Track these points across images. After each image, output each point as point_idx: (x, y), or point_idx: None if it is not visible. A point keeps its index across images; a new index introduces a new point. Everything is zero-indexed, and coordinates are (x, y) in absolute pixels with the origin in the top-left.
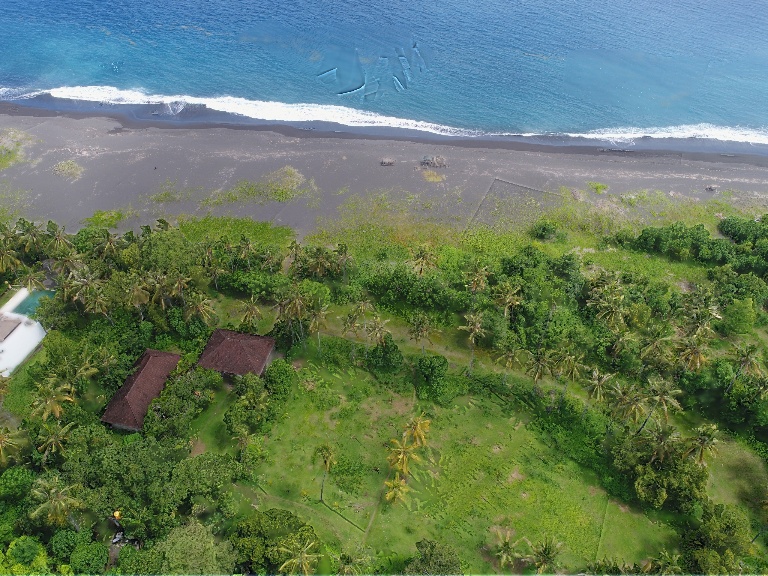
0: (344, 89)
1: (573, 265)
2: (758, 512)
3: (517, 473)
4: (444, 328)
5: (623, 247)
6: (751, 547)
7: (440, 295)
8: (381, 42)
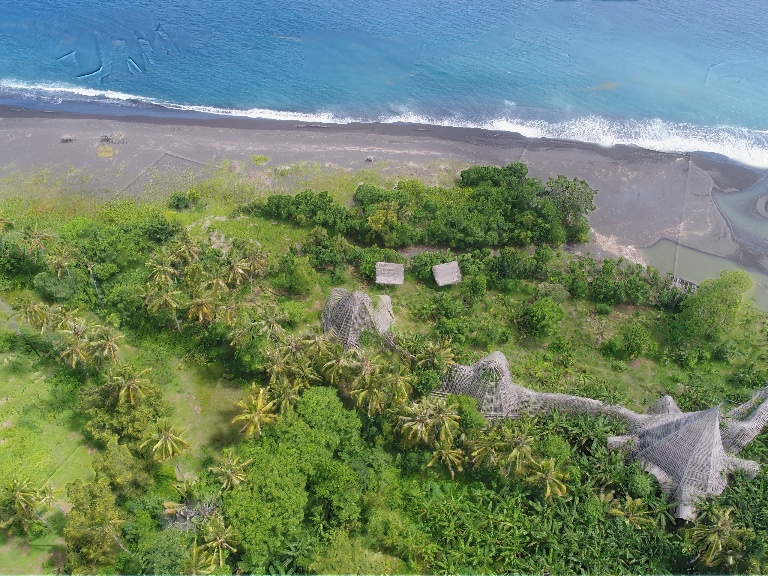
0: (84, 72)
1: (167, 230)
2: None
3: (9, 422)
4: (28, 292)
5: (254, 215)
6: (121, 475)
7: (24, 260)
8: (119, 25)
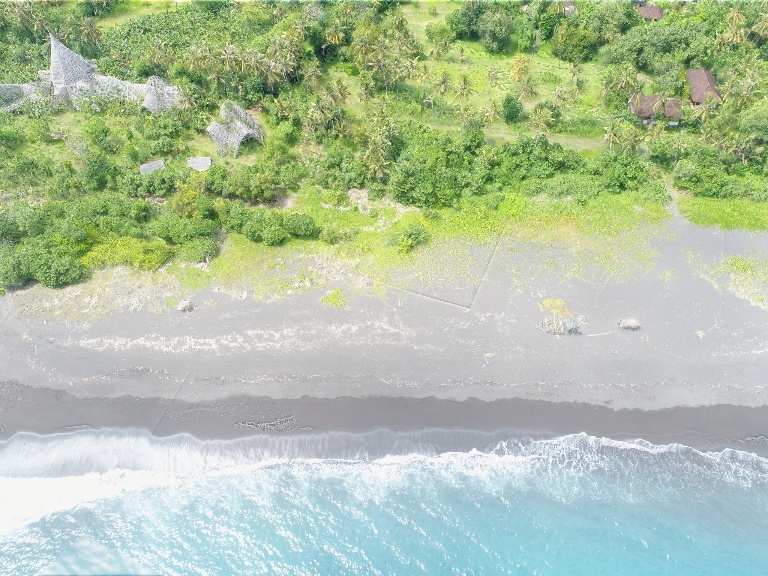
0: None
1: None
2: (325, 84)
3: None
4: None
5: None
6: None
7: (517, 146)
8: None
